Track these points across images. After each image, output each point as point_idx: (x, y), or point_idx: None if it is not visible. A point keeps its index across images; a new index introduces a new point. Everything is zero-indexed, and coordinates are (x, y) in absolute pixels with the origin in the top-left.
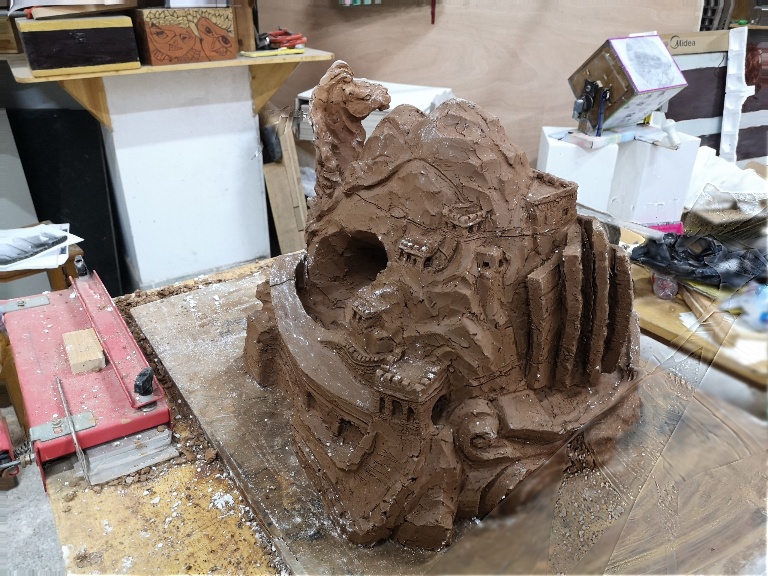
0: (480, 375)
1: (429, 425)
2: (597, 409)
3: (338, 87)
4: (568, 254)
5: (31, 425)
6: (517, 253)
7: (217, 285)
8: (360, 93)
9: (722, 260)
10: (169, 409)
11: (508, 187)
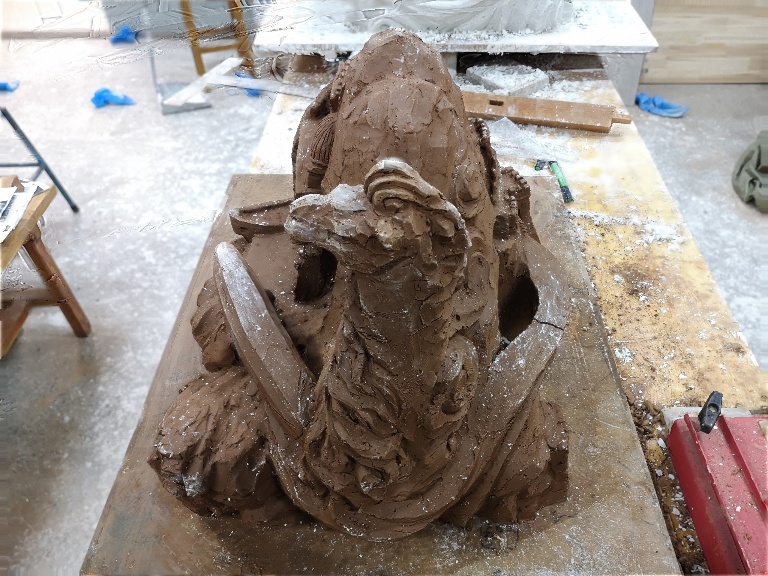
0: None
1: None
2: None
3: None
4: None
5: None
6: None
7: None
8: None
9: None
10: (676, 421)
11: None
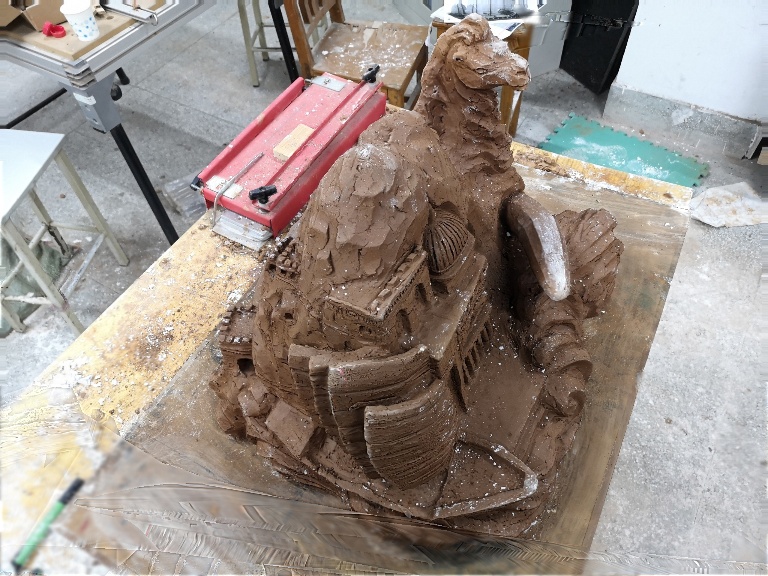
0: (258, 372)
1: (234, 366)
2: (366, 493)
3: (455, 45)
4: (310, 359)
5: (218, 173)
6: (302, 321)
7: None
8: (471, 63)
9: None
10: (271, 220)
11: (318, 265)
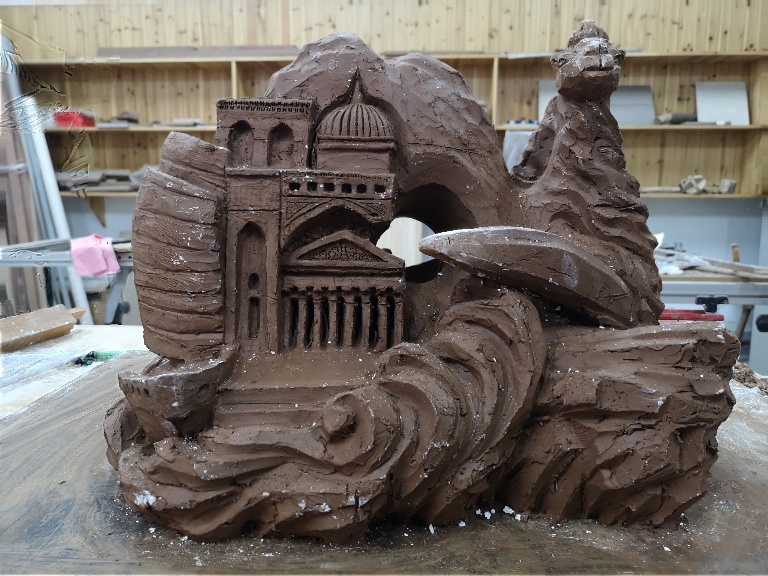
0: None
1: None
2: (152, 363)
3: None
4: None
5: None
6: None
7: (751, 391)
8: None
9: (61, 96)
10: None
11: None
